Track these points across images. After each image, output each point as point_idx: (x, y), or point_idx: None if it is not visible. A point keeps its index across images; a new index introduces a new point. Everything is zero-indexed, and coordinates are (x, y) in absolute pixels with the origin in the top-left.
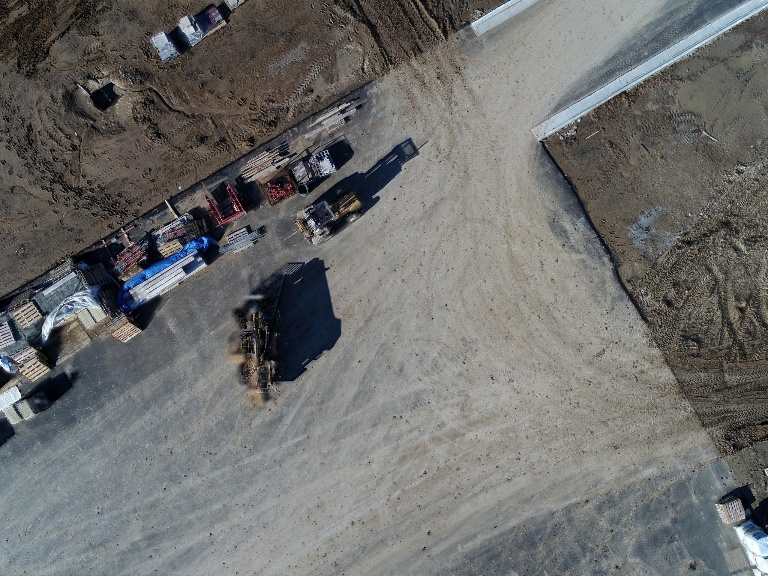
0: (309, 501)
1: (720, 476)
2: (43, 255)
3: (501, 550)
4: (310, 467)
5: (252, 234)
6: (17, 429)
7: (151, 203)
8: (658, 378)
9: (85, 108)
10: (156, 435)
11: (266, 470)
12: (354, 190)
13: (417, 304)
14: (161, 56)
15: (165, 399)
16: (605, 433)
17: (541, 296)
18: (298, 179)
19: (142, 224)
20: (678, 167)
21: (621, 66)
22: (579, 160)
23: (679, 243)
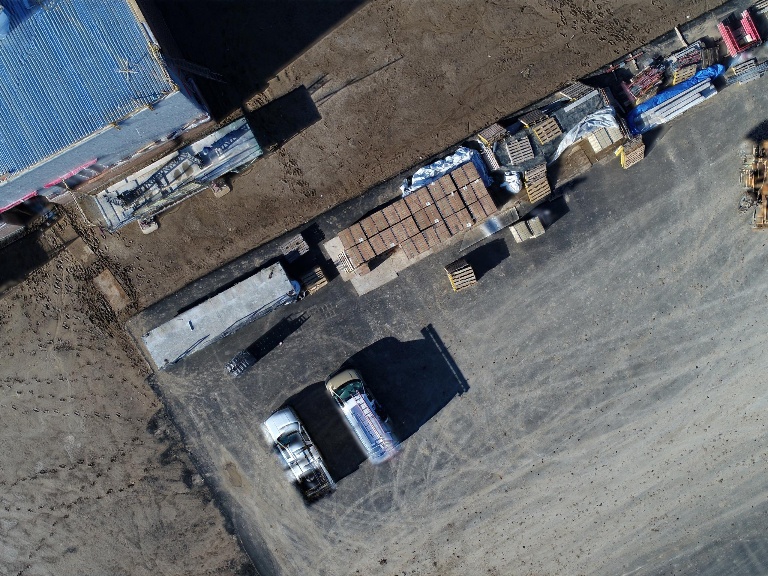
0: None
1: None
2: (548, 77)
3: None
4: None
5: (761, 66)
6: (512, 251)
7: (658, 30)
8: None
9: None
10: (649, 264)
11: (756, 306)
12: None
13: None
14: None
15: (660, 229)
16: None
17: None
18: None
19: (650, 51)
20: None
21: None
22: None
23: None
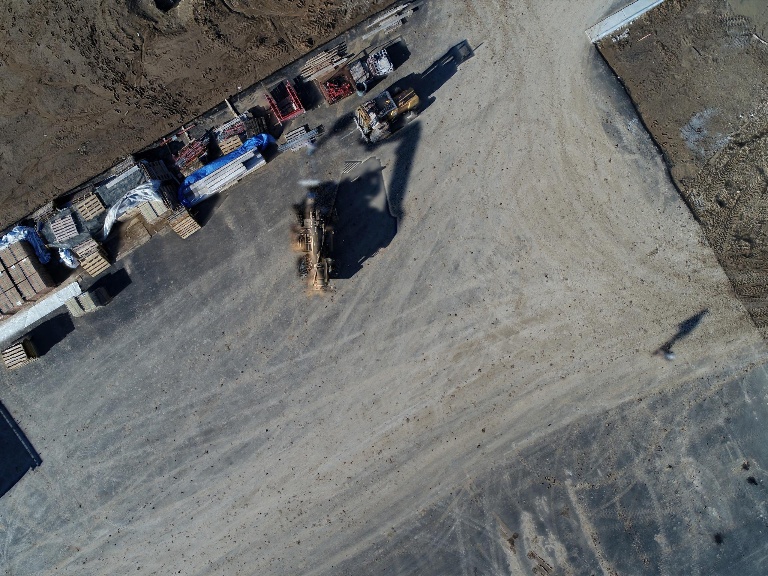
0: (365, 398)
1: None
2: (104, 153)
3: (555, 448)
4: (366, 364)
5: (310, 132)
6: (77, 324)
7: (211, 102)
8: (711, 277)
9: (147, 10)
10: (214, 331)
11: (322, 367)
12: None
13: (472, 203)
14: None
15: (223, 295)
16: (658, 332)
17: (594, 195)
18: (356, 79)
19: (202, 123)
20: (729, 69)
21: None
22: (632, 62)
23: (731, 144)
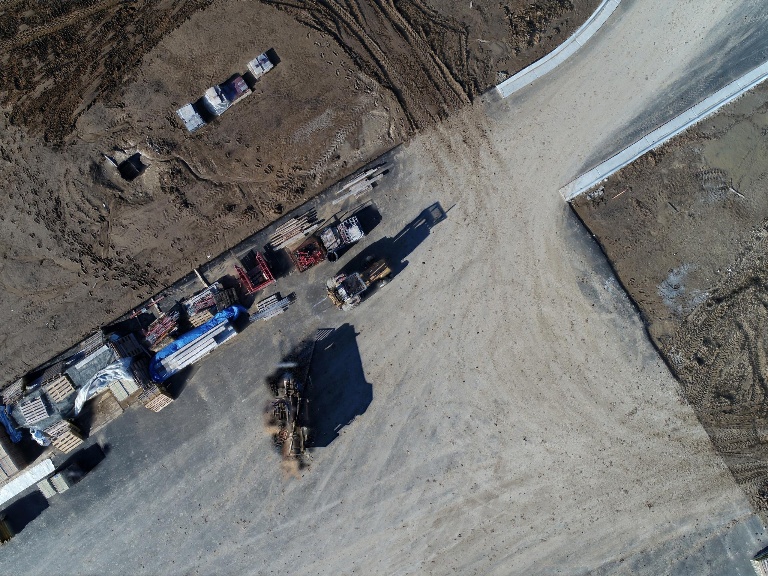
0: (344, 566)
1: (755, 532)
2: (73, 327)
3: None
4: (344, 532)
5: (282, 301)
6: (51, 501)
7: (180, 272)
8: (691, 435)
9: (112, 179)
10: (190, 504)
11: (301, 536)
12: (383, 255)
13: (448, 367)
14: (188, 127)
15: (198, 468)
16: (639, 492)
17: (572, 356)
18: (327, 245)
19: (172, 294)
20: (706, 224)
21: (647, 125)
22: (607, 219)
23: (708, 300)
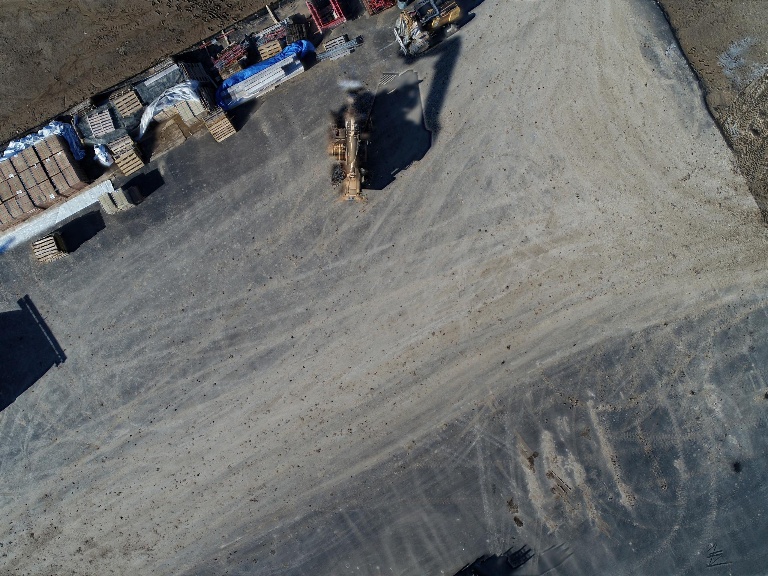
0: (391, 309)
1: None
2: (143, 53)
3: (579, 369)
4: (394, 276)
5: (349, 42)
6: (108, 222)
7: (252, 8)
8: (741, 205)
9: None
10: (244, 236)
11: (350, 276)
12: None
13: (507, 120)
14: None
15: (255, 201)
16: (687, 257)
17: (629, 119)
18: None
19: (242, 28)
20: None
21: None
22: None
23: (767, 74)
